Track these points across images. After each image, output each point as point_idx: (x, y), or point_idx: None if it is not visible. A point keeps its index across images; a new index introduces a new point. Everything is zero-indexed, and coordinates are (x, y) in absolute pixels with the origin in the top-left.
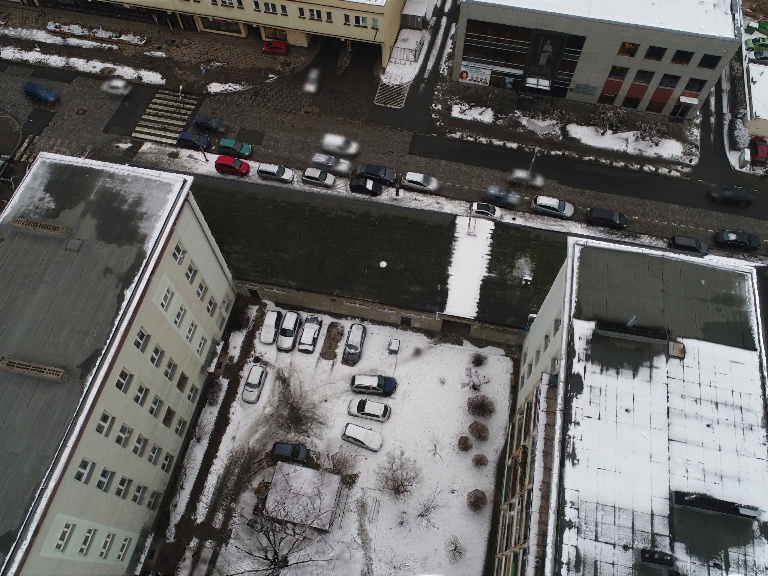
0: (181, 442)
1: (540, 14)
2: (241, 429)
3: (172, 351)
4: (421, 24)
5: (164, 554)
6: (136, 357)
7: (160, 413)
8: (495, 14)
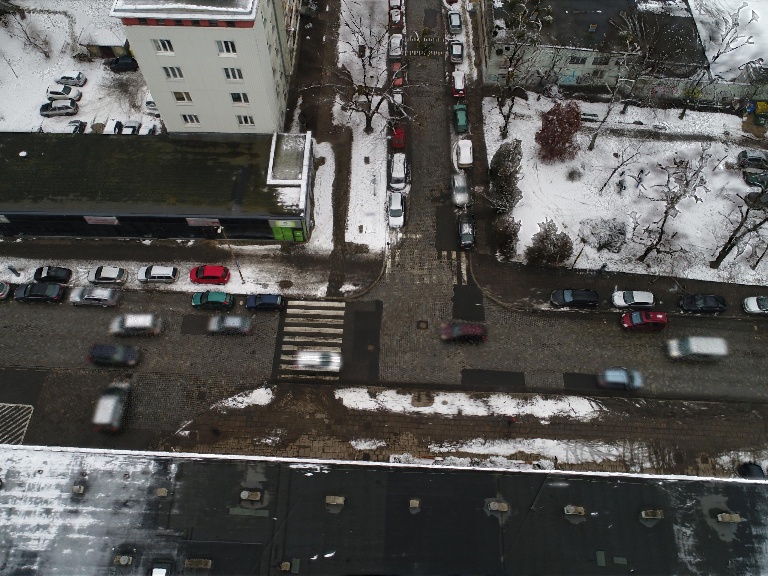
0: None
1: None
2: None
3: None
4: None
5: None
6: None
7: None
8: None
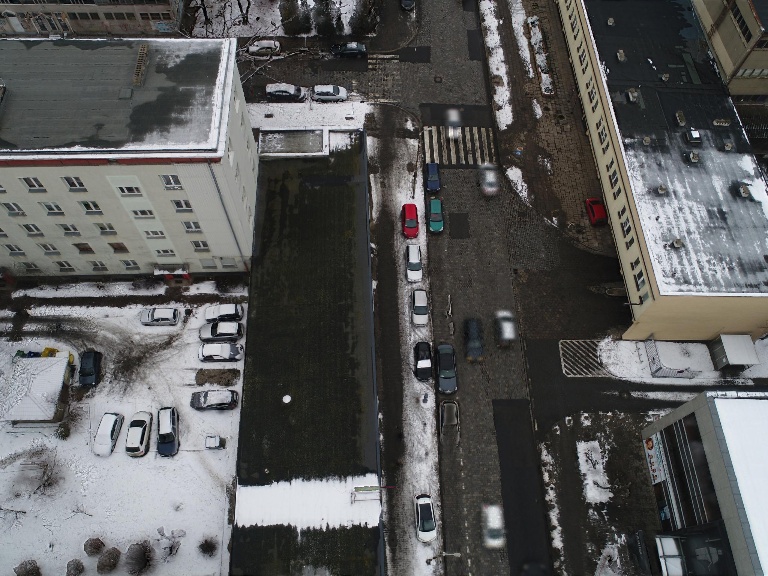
0: (92, 273)
1: (740, 520)
2: (116, 320)
3: (116, 222)
4: (722, 366)
5: (2, 294)
6: (59, 186)
7: (72, 237)
8: (713, 448)
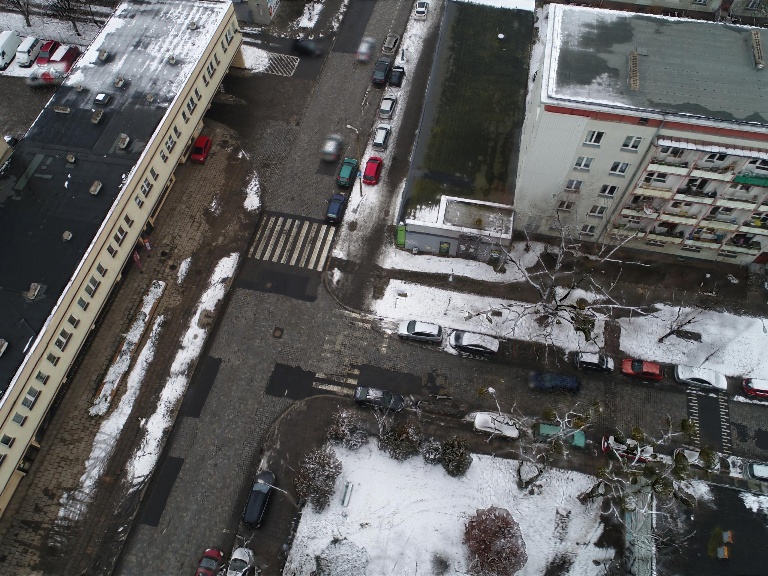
0: None
1: None
2: None
3: None
4: None
5: None
6: None
7: None
8: None
